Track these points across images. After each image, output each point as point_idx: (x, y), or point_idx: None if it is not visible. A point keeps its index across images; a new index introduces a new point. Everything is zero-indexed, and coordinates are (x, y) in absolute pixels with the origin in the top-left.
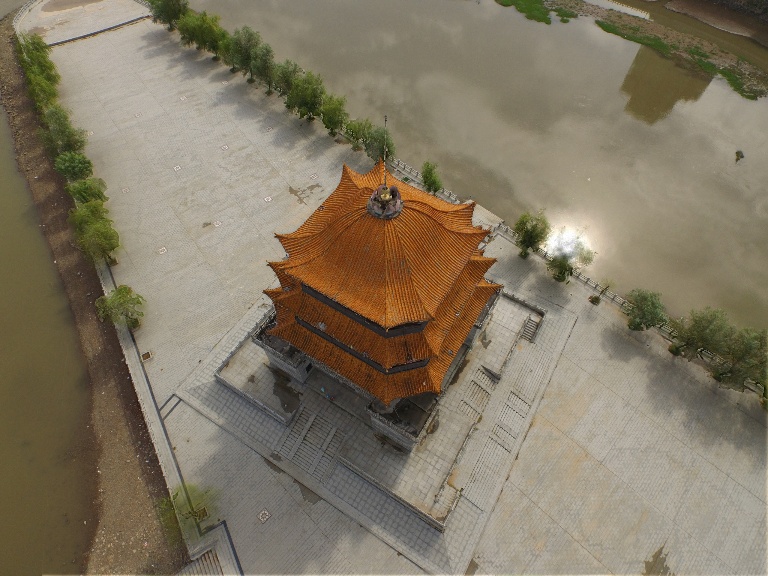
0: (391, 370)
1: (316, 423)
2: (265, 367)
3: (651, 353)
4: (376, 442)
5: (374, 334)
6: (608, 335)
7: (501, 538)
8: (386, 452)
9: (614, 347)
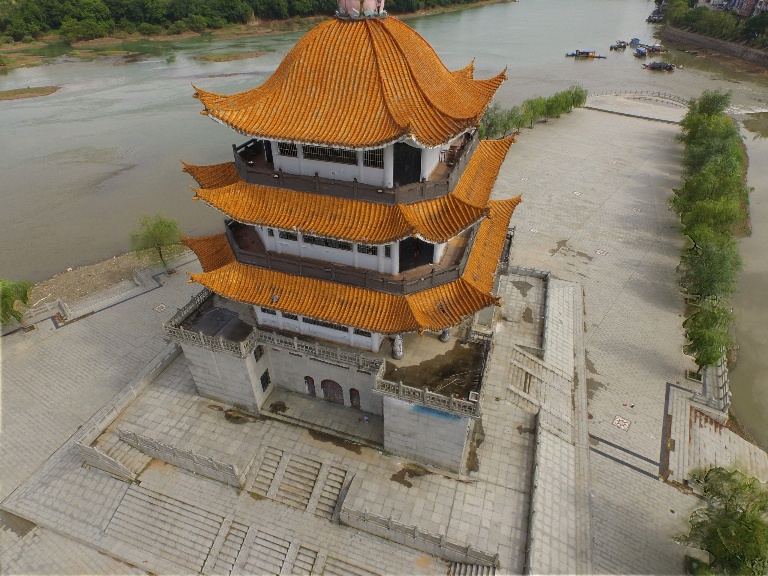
0: None
1: None
2: None
3: None
4: None
5: None
6: None
7: (50, 572)
8: None
9: None
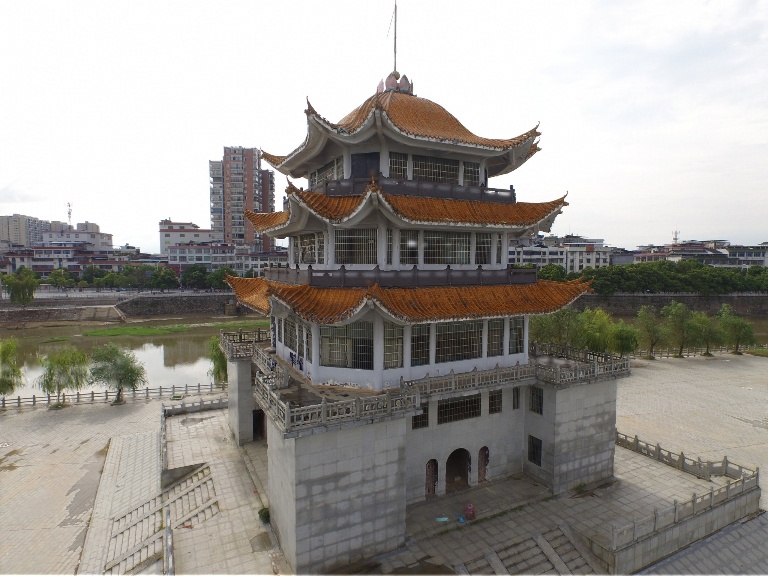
0: None
1: (512, 567)
2: None
3: None
4: (587, 500)
5: (502, 206)
6: None
7: None
8: (611, 496)
9: None
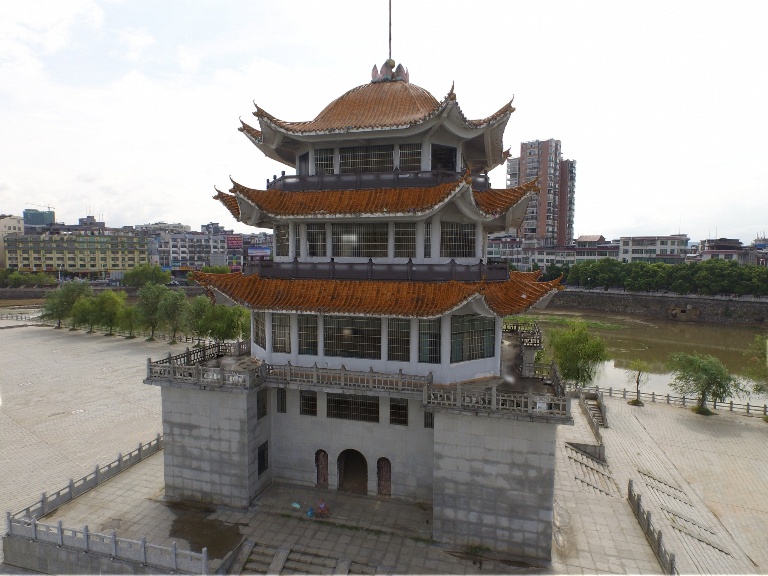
0: (459, 270)
1: (290, 570)
2: (151, 502)
3: (754, 427)
4: (459, 563)
5: (418, 191)
6: (687, 422)
7: None
8: (495, 575)
9: (707, 429)
